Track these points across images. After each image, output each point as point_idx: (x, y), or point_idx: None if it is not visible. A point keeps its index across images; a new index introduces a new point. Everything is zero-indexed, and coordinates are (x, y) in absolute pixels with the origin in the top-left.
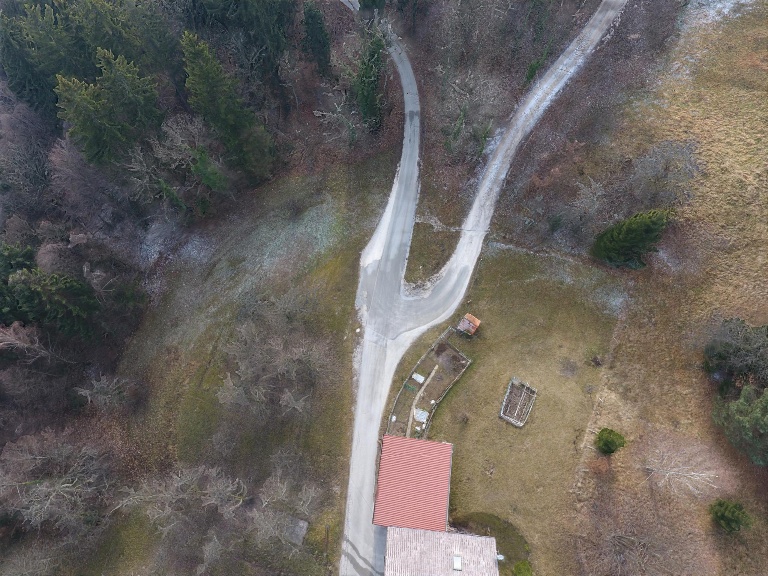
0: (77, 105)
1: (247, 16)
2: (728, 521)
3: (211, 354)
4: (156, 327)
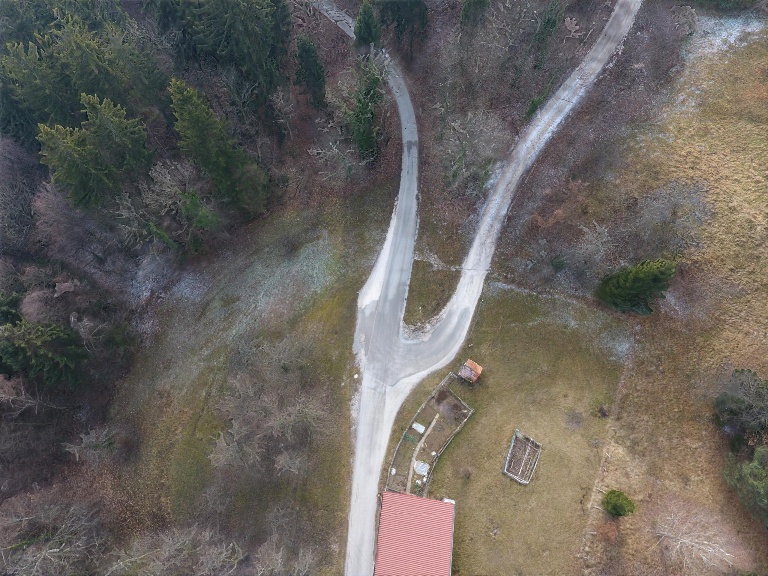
0: (61, 152)
1: (238, 52)
2: None
3: (204, 401)
4: (148, 369)
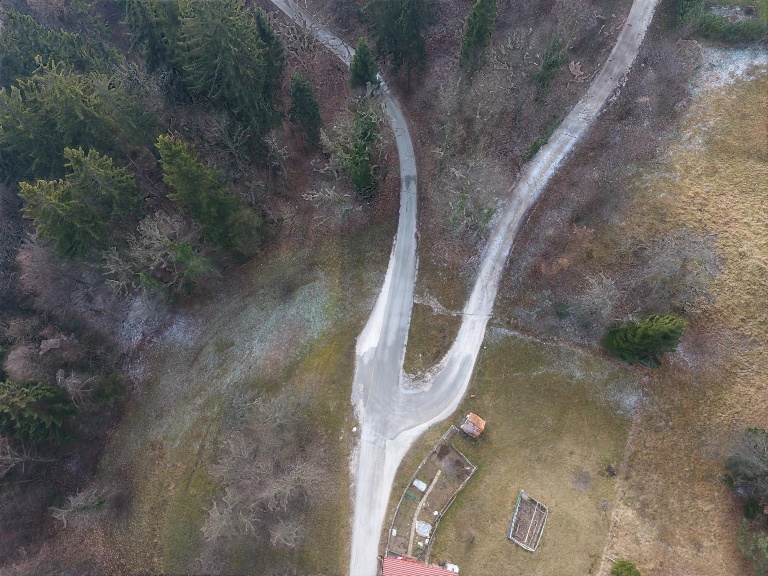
0: (44, 208)
1: (230, 95)
2: None
3: (198, 454)
4: (140, 418)
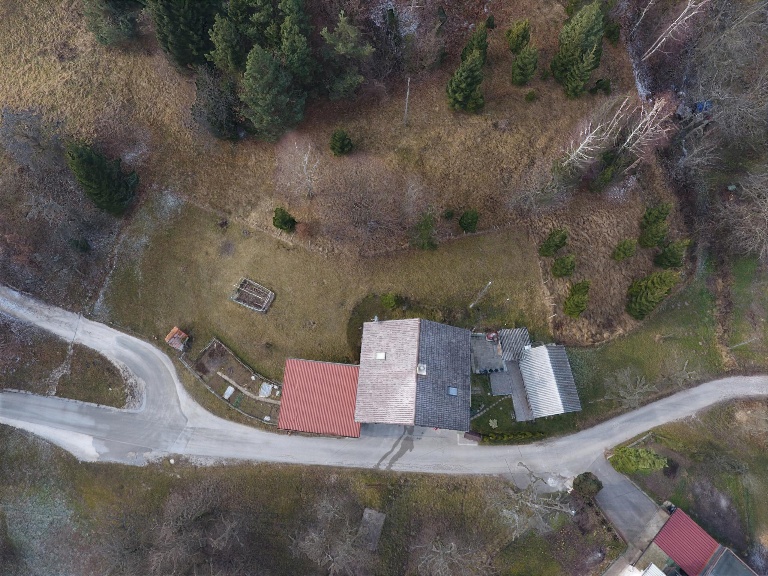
0: None
1: None
2: (344, 145)
3: None
4: None
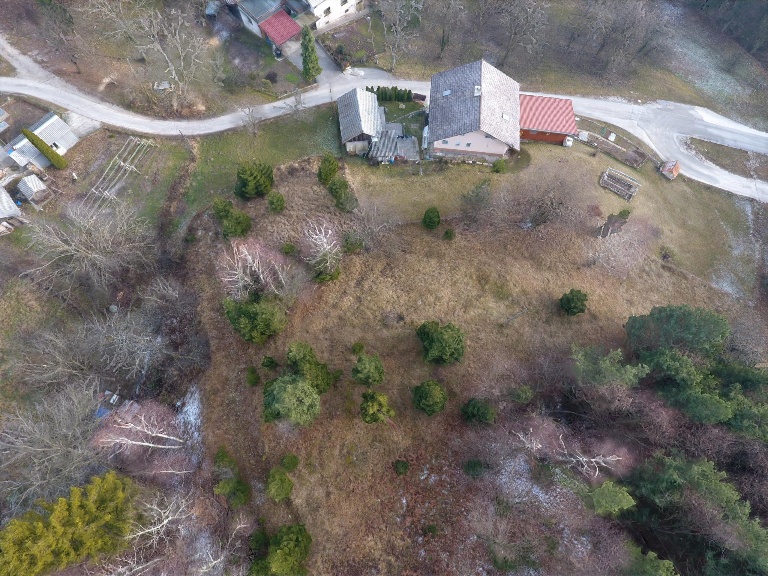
0: None
1: None
2: None
3: None
4: None
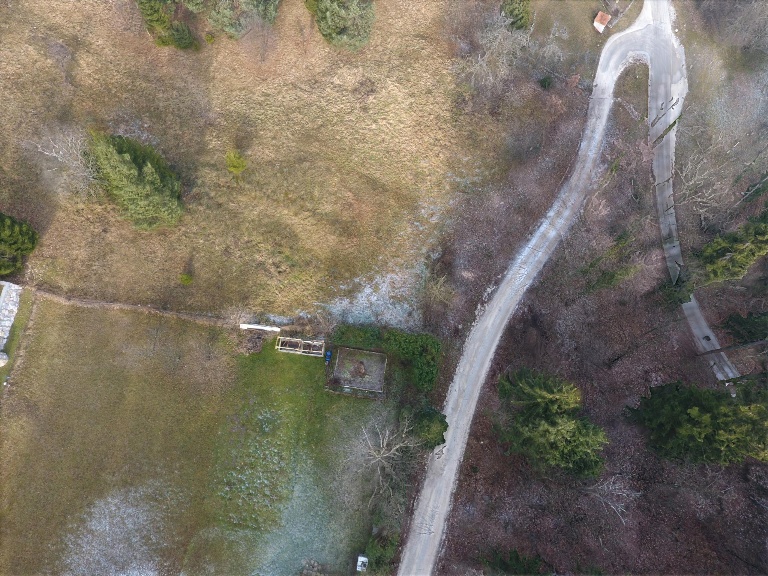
0: None
1: None
2: None
3: None
4: None
